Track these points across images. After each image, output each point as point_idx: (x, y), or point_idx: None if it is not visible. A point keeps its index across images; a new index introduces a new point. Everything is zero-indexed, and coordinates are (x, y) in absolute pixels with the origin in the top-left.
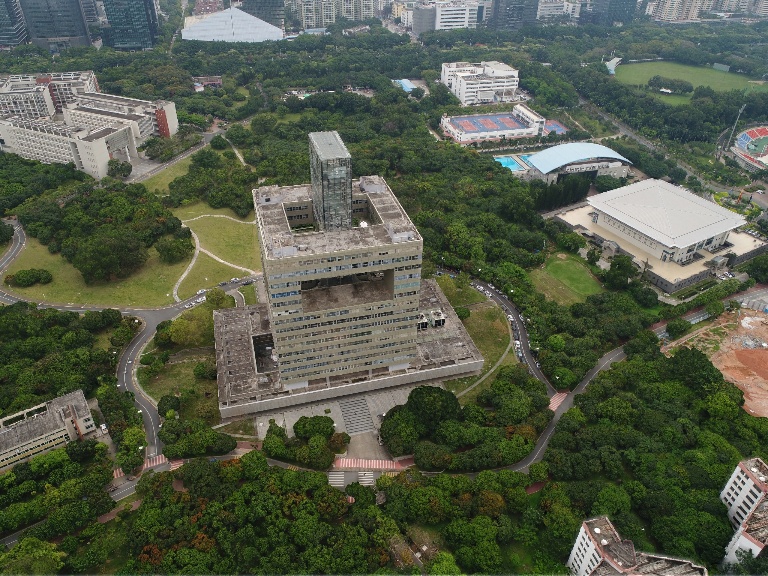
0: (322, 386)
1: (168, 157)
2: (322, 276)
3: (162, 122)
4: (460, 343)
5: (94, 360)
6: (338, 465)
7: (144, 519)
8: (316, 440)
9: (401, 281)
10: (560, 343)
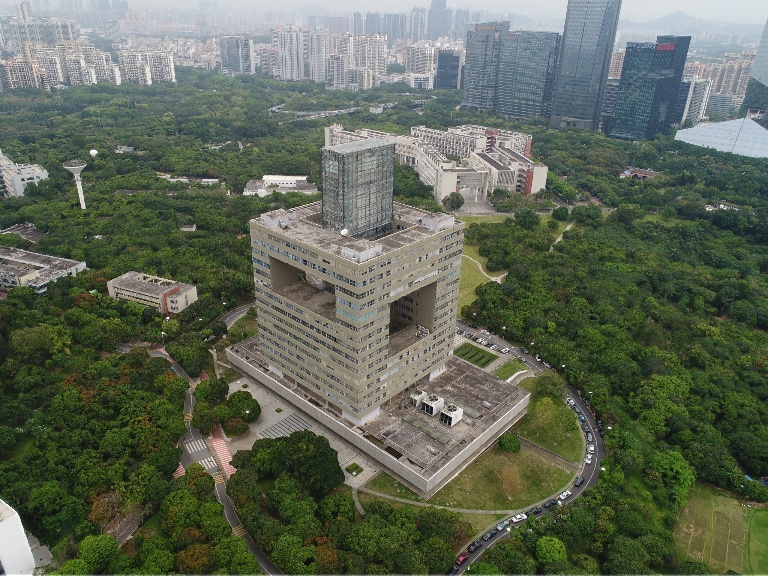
0: (290, 385)
1: (506, 209)
2: (283, 259)
3: (528, 181)
4: (433, 449)
5: (239, 284)
6: (213, 441)
7: (99, 363)
8: (221, 408)
9: (342, 305)
10: (546, 551)
